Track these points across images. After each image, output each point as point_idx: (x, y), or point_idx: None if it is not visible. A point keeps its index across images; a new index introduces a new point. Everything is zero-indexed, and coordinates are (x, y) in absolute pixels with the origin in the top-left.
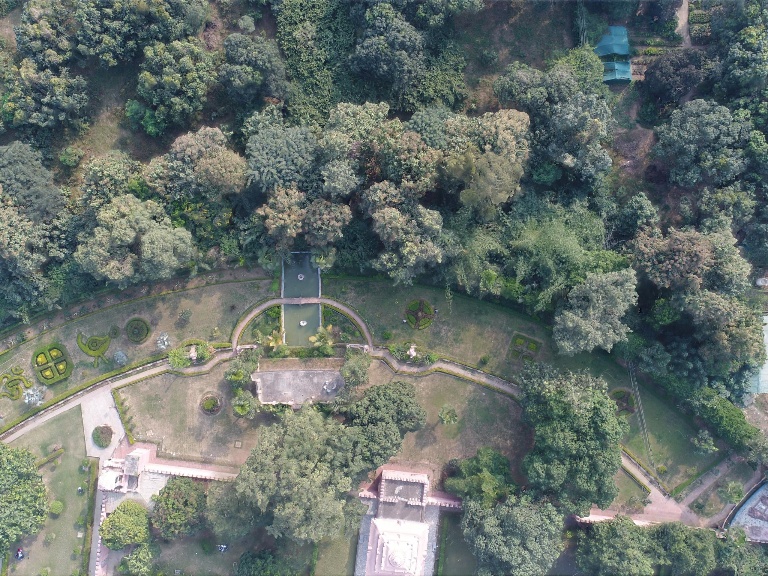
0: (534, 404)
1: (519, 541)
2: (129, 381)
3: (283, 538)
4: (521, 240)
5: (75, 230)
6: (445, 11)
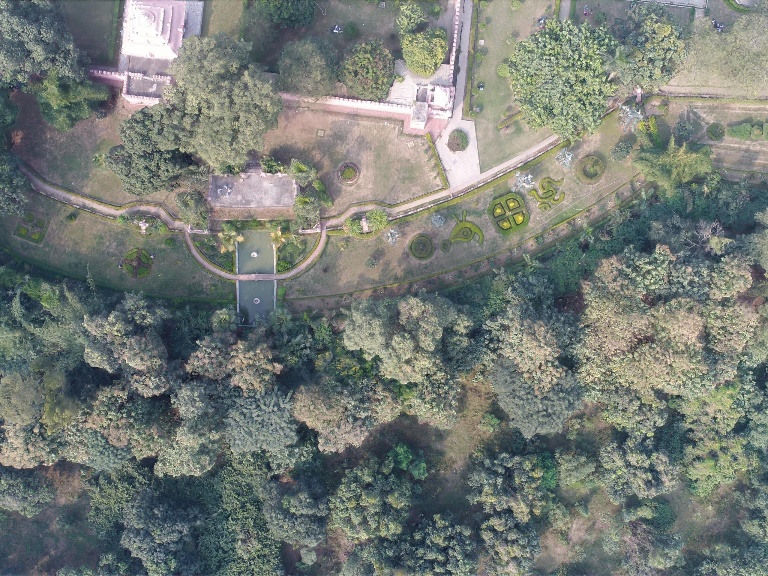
0: (3, 173)
1: (5, 36)
2: (432, 197)
3: (269, 39)
4: (8, 337)
5: (477, 348)
6: (98, 568)
